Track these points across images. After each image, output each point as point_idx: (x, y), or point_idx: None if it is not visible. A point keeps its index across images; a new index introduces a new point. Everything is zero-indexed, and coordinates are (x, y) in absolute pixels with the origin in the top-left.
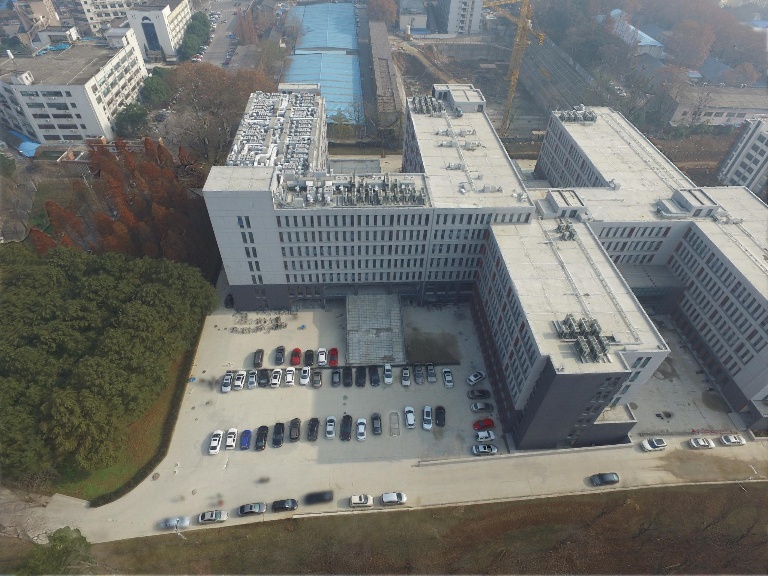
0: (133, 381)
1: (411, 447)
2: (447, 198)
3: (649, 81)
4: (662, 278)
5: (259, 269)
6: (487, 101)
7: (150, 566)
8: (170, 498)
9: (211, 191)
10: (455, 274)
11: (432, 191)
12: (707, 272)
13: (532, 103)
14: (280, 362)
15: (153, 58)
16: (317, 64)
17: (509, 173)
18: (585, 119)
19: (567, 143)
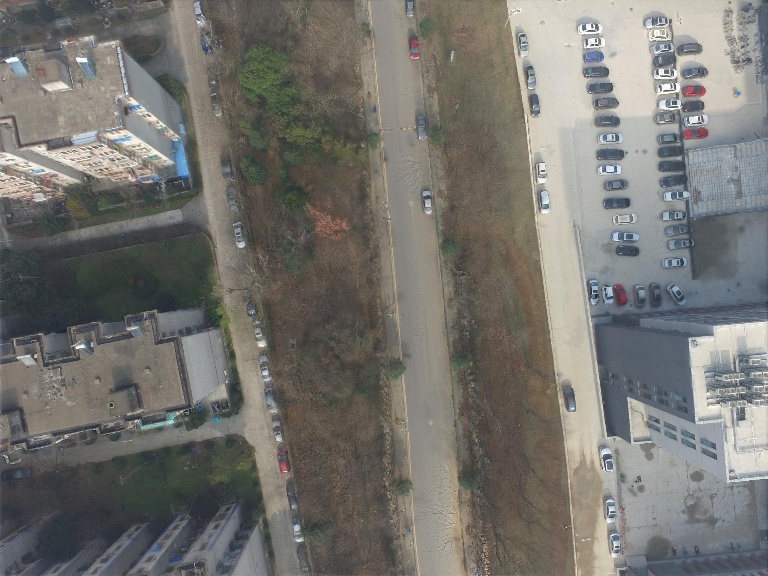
0: None
1: (593, 220)
2: None
3: None
4: None
5: None
6: None
7: (484, 5)
8: (537, 3)
9: None
10: None
11: None
12: None
13: None
14: (686, 74)
15: None
16: None
17: None
18: None
19: None
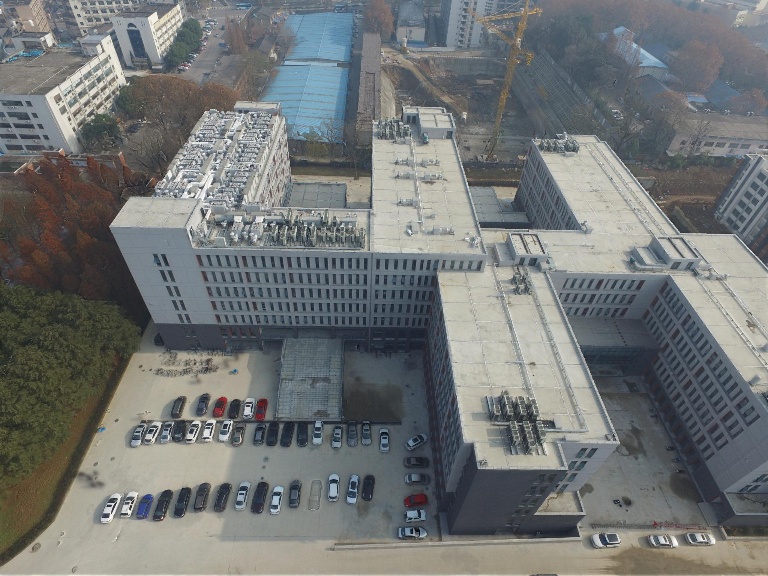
0: (14, 440)
1: (329, 525)
2: (390, 240)
3: None
4: (635, 335)
5: (185, 308)
6: (480, 119)
7: None
8: (46, 575)
9: (119, 227)
10: (404, 320)
11: (375, 231)
12: (682, 335)
13: (528, 123)
14: (201, 413)
15: (139, 65)
16: (304, 76)
17: (466, 212)
18: (566, 149)
19: (544, 175)
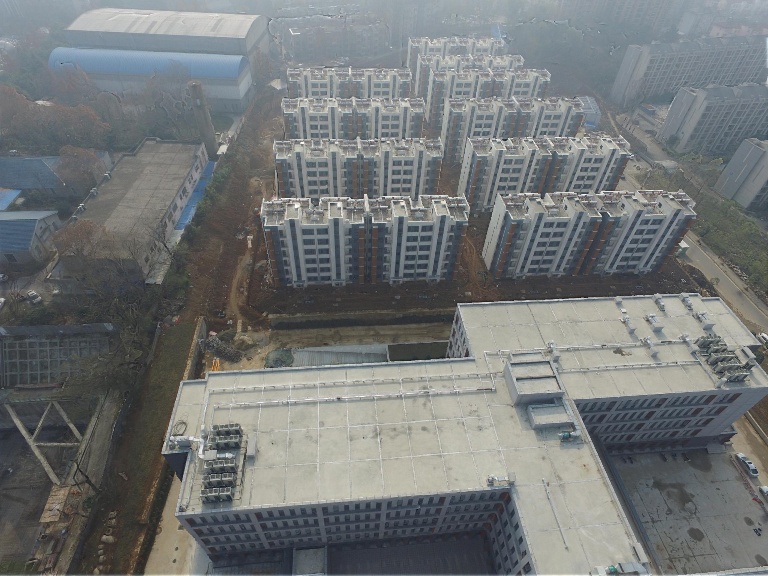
0: None
1: None
2: None
3: (111, 285)
4: None
5: None
6: None
7: None
8: None
9: None
10: None
11: None
12: None
13: None
14: None
15: None
16: None
17: None
18: (230, 448)
19: None
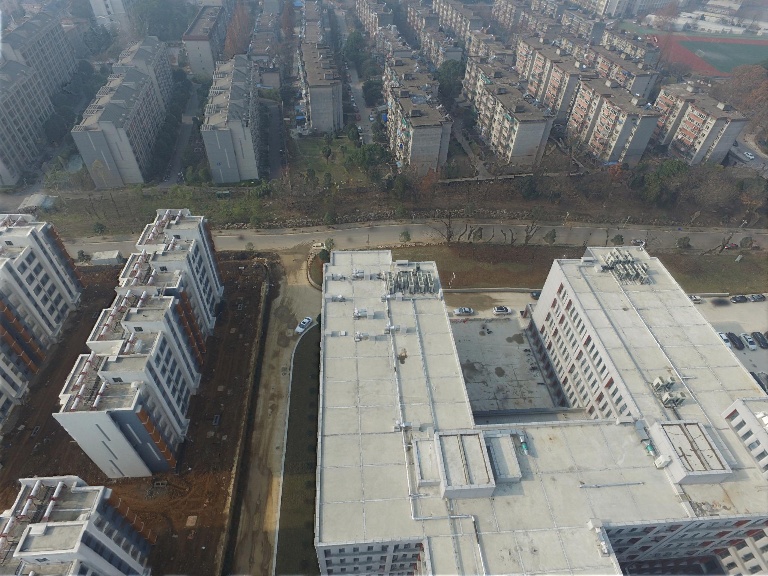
0: None
1: None
2: None
3: None
4: None
5: None
6: None
7: None
8: None
9: None
10: None
11: None
12: None
13: None
14: None
15: None
16: None
17: None
18: None
19: None
